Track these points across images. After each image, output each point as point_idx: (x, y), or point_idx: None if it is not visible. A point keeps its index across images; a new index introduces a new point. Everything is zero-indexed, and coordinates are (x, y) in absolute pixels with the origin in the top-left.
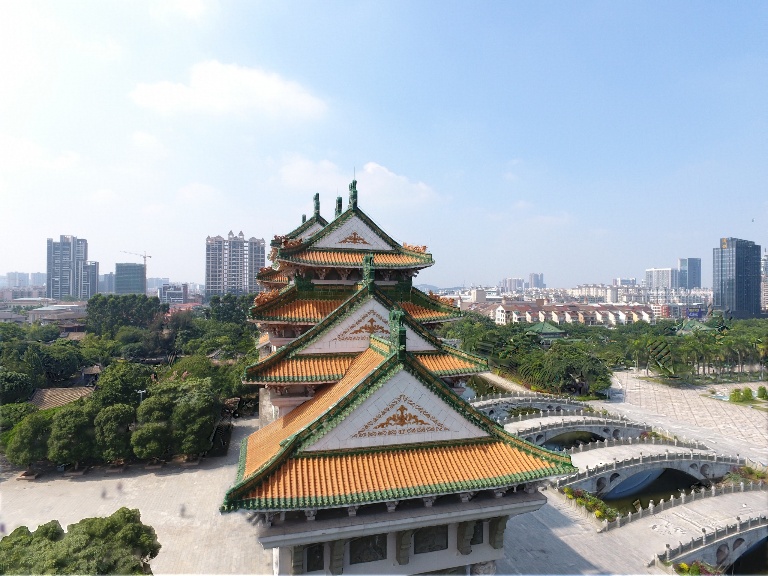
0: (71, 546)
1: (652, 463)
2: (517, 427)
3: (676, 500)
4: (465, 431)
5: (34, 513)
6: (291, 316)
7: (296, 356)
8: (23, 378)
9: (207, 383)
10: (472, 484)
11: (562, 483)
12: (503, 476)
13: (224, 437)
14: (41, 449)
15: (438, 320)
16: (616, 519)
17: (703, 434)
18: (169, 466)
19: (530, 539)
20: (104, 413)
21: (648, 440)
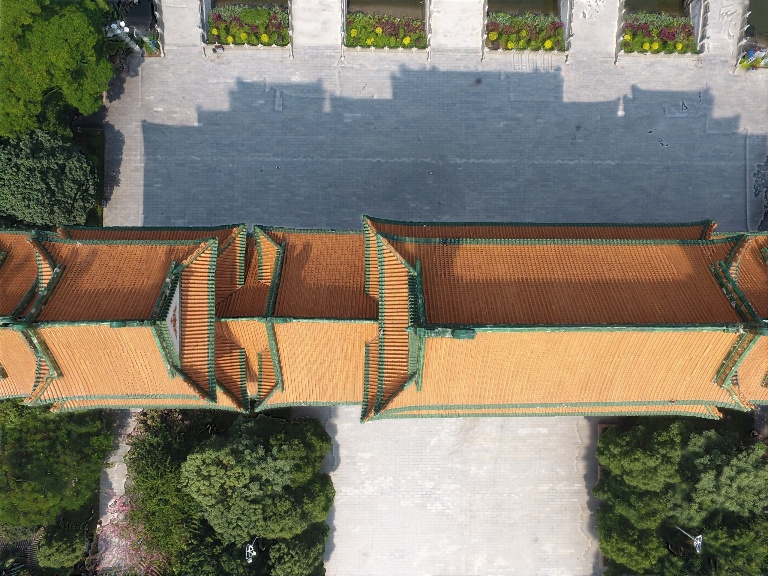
0: None
1: None
2: None
3: None
4: None
5: (404, 563)
6: None
7: None
8: None
9: (218, 457)
10: None
11: None
12: None
13: None
14: None
15: None
16: (569, 39)
17: None
18: None
19: (561, 127)
20: None
21: None
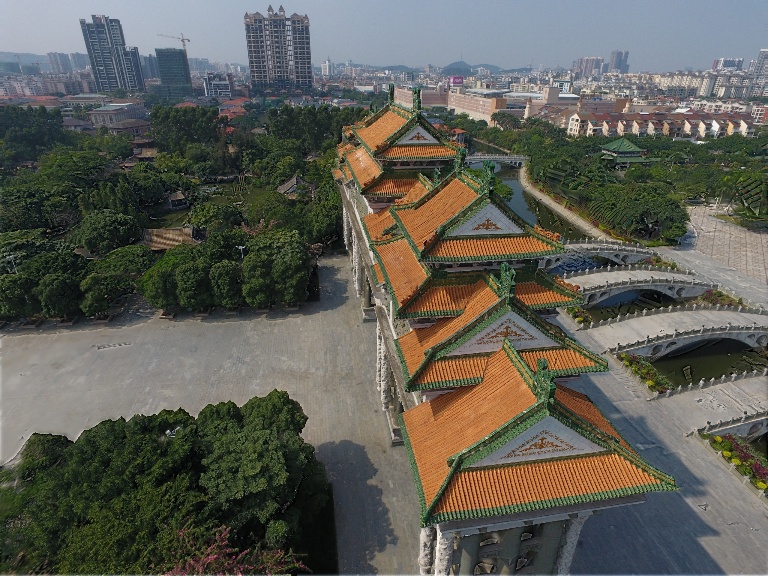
0: (260, 439)
1: (711, 334)
2: (583, 282)
3: (727, 378)
4: (589, 449)
5: (186, 352)
6: (430, 309)
7: (441, 358)
8: (131, 221)
9: (296, 238)
10: (593, 498)
11: (621, 349)
12: (617, 490)
13: (314, 281)
14: (172, 297)
15: (561, 306)
16: None
17: None
18: (275, 310)
19: None
20: (216, 269)
21: (713, 307)
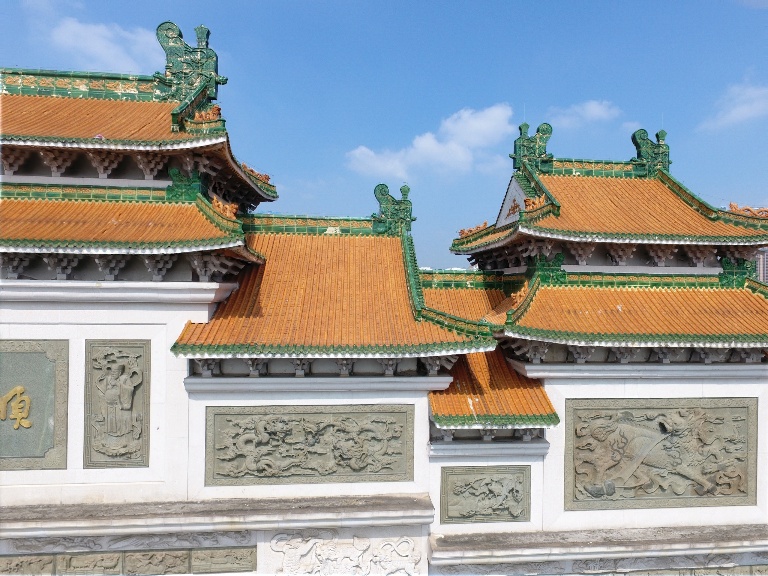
0: None
1: None
2: None
3: None
4: None
5: None
6: None
7: None
8: None
9: None
10: None
11: None
12: None
13: None
14: None
15: None
16: None
17: None
18: None
19: None
20: None
21: None
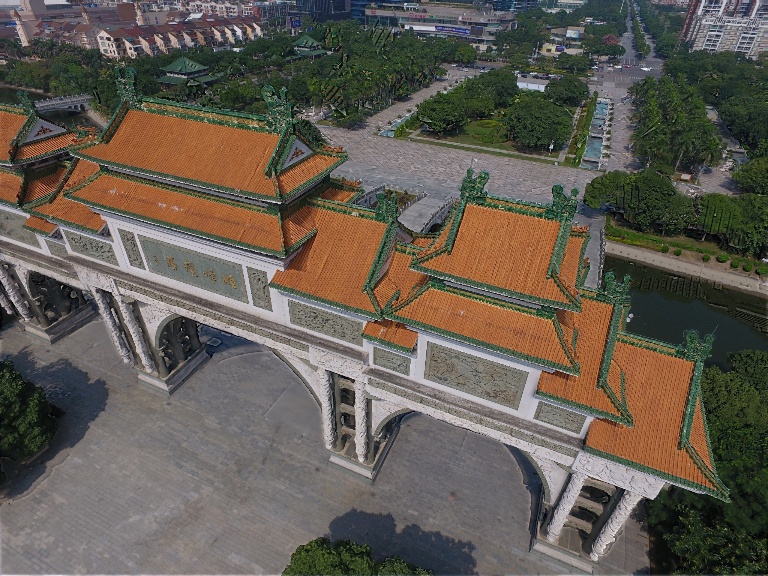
0: None
1: (428, 227)
2: None
3: None
4: None
5: None
6: None
7: None
8: None
9: None
10: None
11: None
12: None
13: None
14: None
15: None
16: None
17: (411, 180)
18: (8, 477)
19: None
20: None
21: (407, 205)
